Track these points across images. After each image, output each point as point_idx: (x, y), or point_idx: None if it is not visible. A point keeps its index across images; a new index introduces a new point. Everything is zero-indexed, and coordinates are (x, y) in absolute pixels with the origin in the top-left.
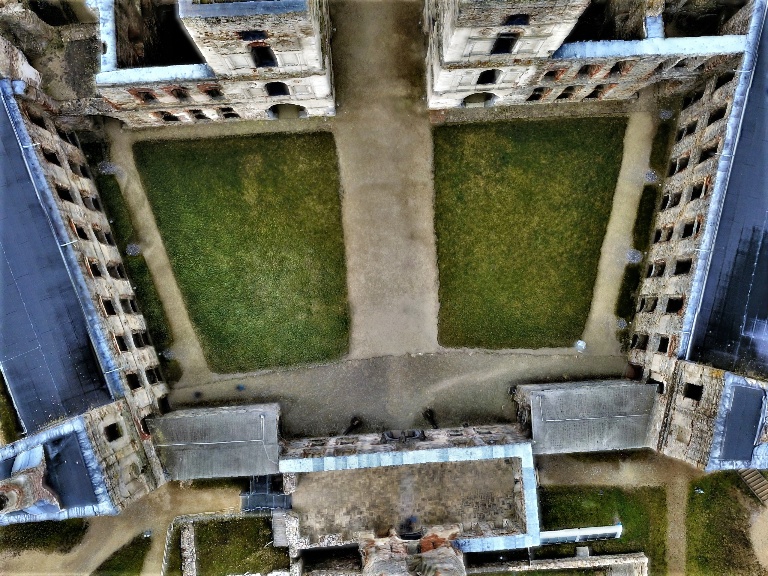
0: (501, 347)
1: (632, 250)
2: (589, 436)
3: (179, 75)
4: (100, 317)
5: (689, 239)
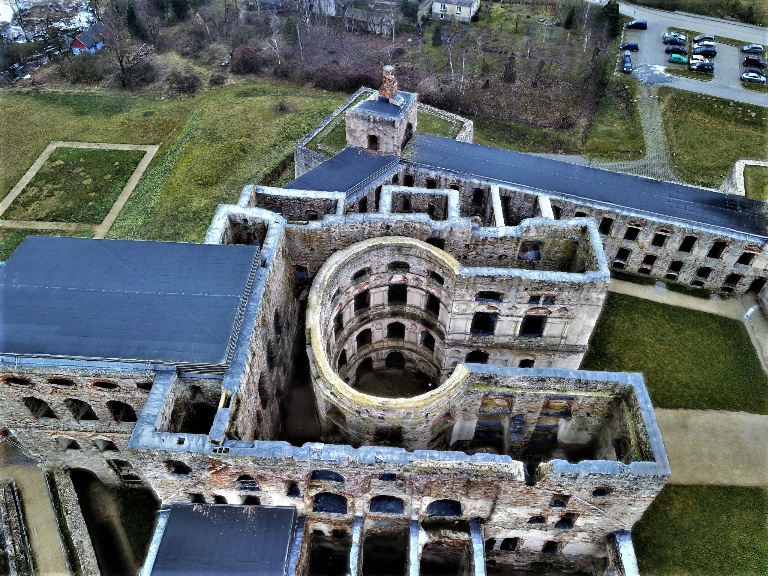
0: (763, 371)
1: (657, 286)
2: None
3: (635, 571)
4: None
5: (671, 238)
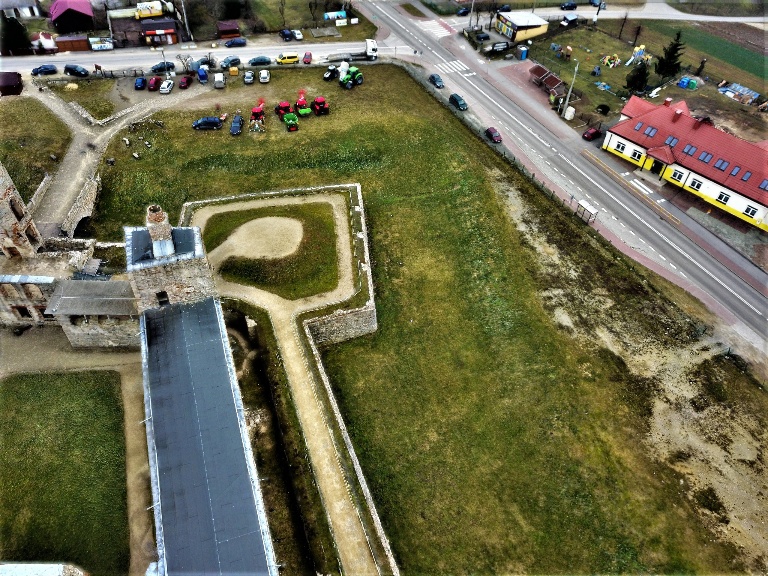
0: None
1: None
2: None
3: None
4: None
5: None
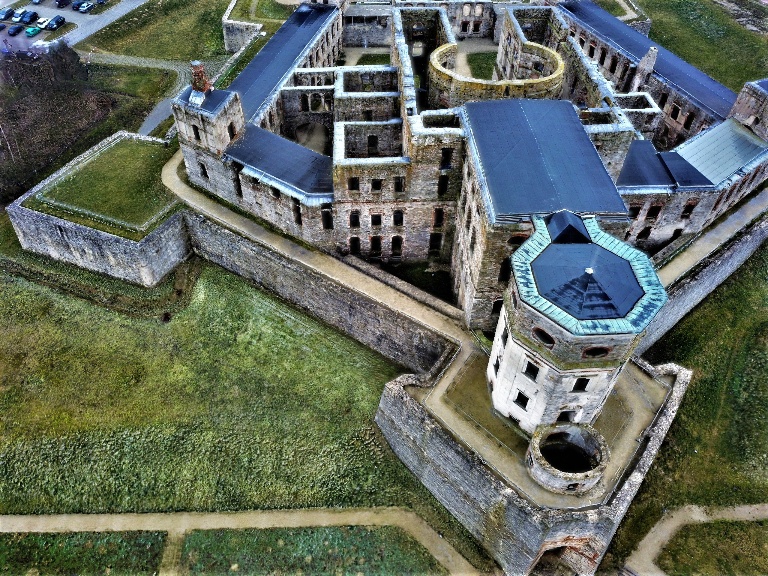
0: None
1: None
2: (372, 7)
3: None
4: (572, 23)
5: None
